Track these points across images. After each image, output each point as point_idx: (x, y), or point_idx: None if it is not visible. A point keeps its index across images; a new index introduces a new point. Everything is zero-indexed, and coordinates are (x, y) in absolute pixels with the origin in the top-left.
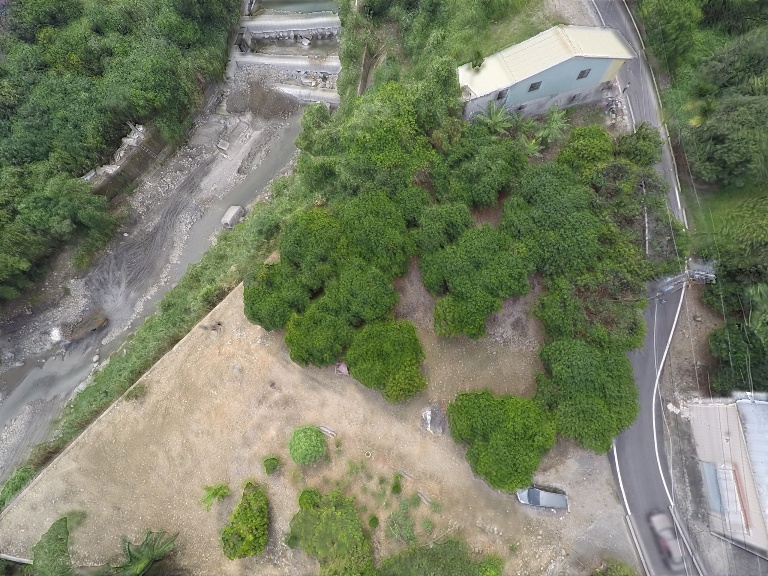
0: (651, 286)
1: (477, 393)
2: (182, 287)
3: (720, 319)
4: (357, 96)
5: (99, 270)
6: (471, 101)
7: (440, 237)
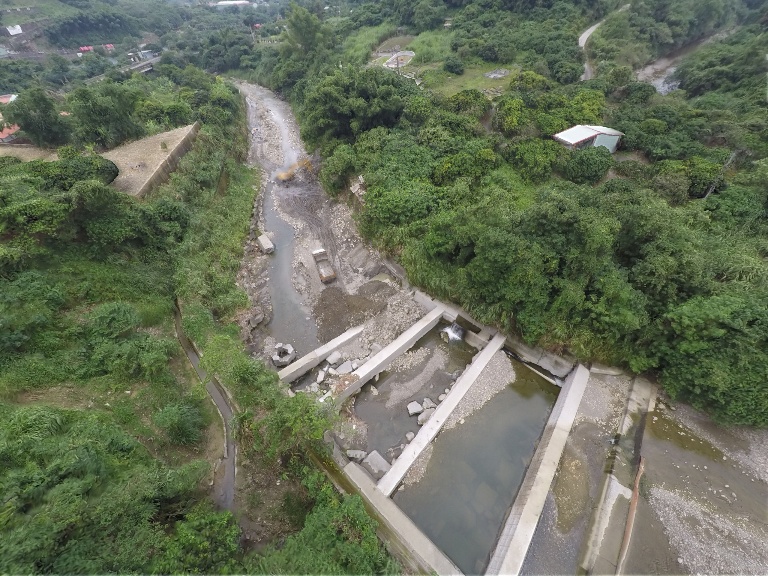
0: None
1: None
2: None
3: None
4: None
5: (319, 189)
6: None
7: None
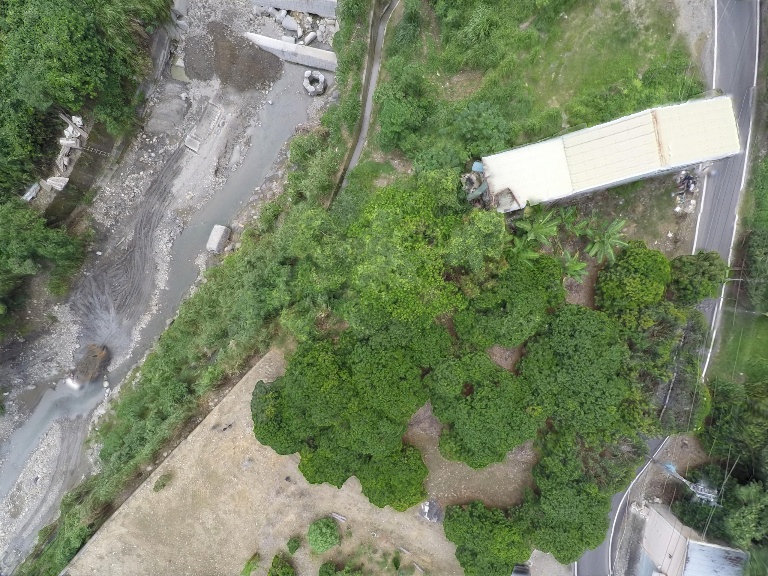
0: (653, 444)
1: (471, 490)
2: (178, 331)
3: (705, 453)
4: (362, 91)
5: (81, 293)
6: (512, 212)
7: (455, 392)
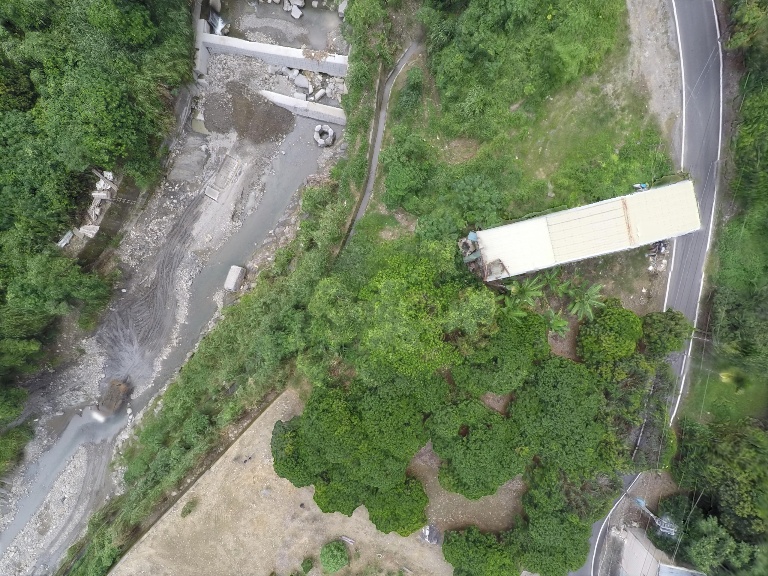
0: (627, 480)
1: (467, 515)
2: (198, 364)
3: (675, 484)
4: (368, 150)
5: (107, 327)
6: (503, 279)
7: (453, 435)
